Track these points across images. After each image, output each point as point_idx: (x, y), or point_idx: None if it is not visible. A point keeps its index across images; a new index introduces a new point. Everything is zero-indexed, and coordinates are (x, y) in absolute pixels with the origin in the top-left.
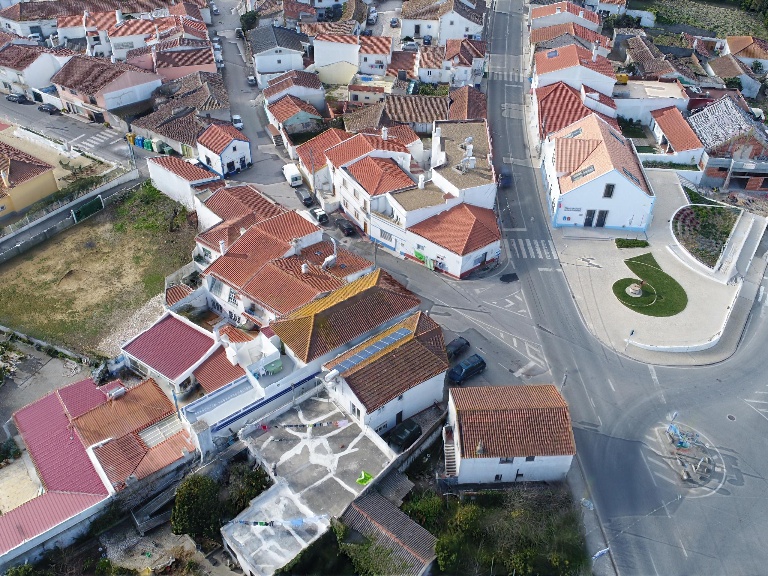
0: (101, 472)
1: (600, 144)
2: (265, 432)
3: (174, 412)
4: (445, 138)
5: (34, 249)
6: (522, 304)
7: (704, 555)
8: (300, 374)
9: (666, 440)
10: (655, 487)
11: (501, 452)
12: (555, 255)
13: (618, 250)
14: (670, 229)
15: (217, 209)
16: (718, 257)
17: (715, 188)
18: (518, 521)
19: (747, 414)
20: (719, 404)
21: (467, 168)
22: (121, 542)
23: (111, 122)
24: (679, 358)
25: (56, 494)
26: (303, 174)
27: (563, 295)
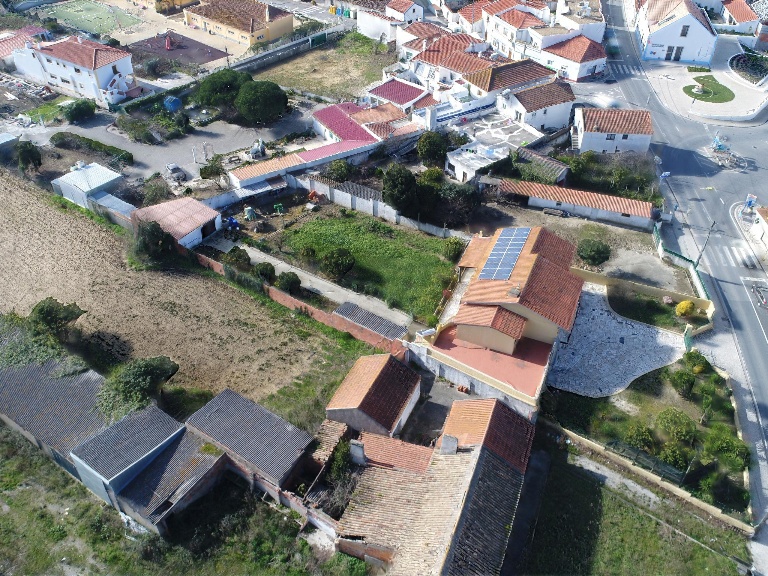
0: (373, 133)
1: (681, 3)
2: (464, 125)
3: (407, 117)
4: (568, 1)
5: (288, 59)
6: (620, 93)
7: (727, 192)
8: (482, 101)
9: (711, 151)
10: (701, 167)
11: (608, 130)
12: (643, 73)
13: (689, 73)
14: (728, 64)
15: (414, 33)
16: (761, 80)
17: (766, 51)
18: (617, 160)
19: (766, 147)
20: (748, 142)
21: (585, 15)
22: (385, 167)
23: (317, 0)
24: (725, 123)
25: (349, 141)
26: (463, 28)
27: (648, 91)
